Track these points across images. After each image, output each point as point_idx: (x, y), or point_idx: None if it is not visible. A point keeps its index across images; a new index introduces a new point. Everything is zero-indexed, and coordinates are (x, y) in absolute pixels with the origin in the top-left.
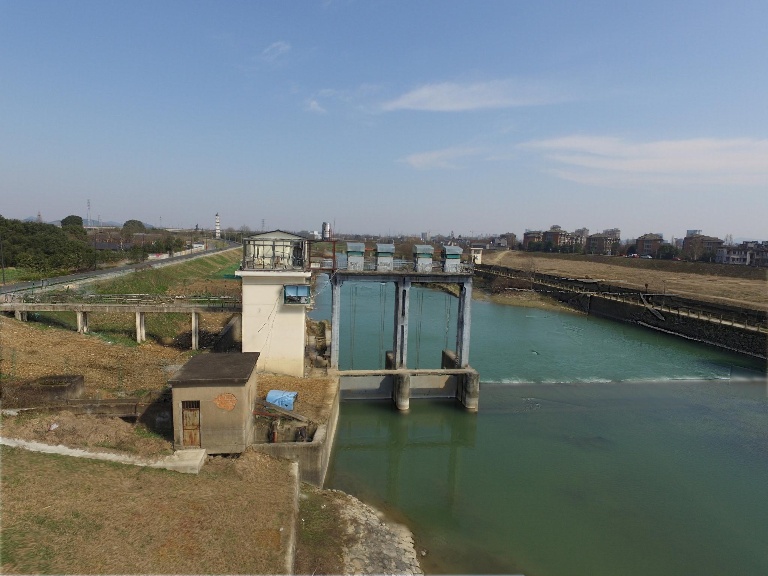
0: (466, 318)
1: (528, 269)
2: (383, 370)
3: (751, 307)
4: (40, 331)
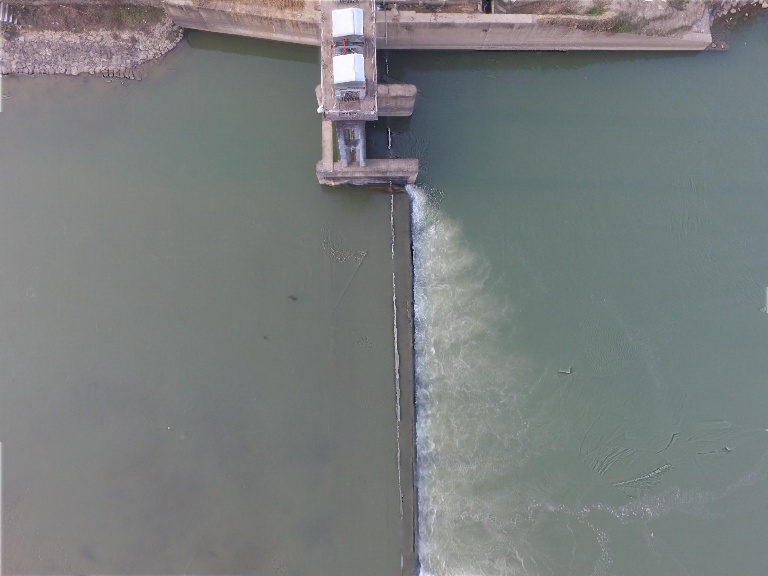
0: None
1: None
2: None
3: None
4: None
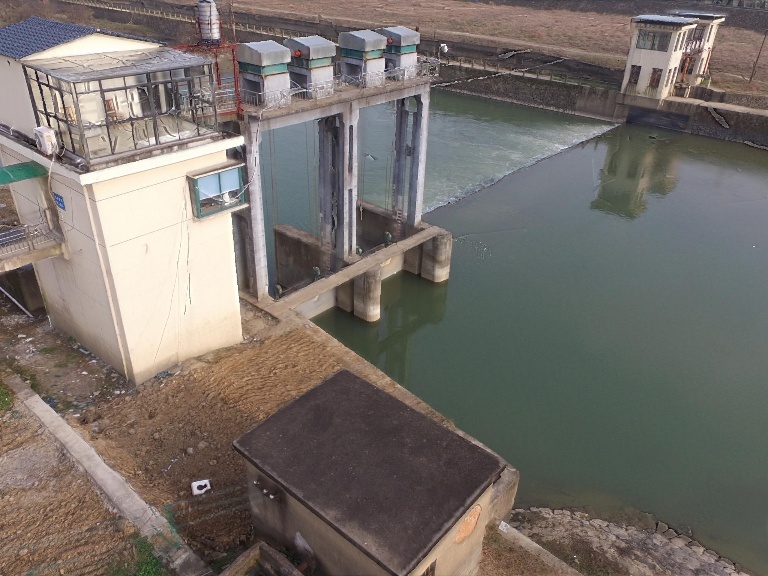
0: (422, 151)
1: (226, 8)
2: (341, 273)
3: (499, 44)
4: None
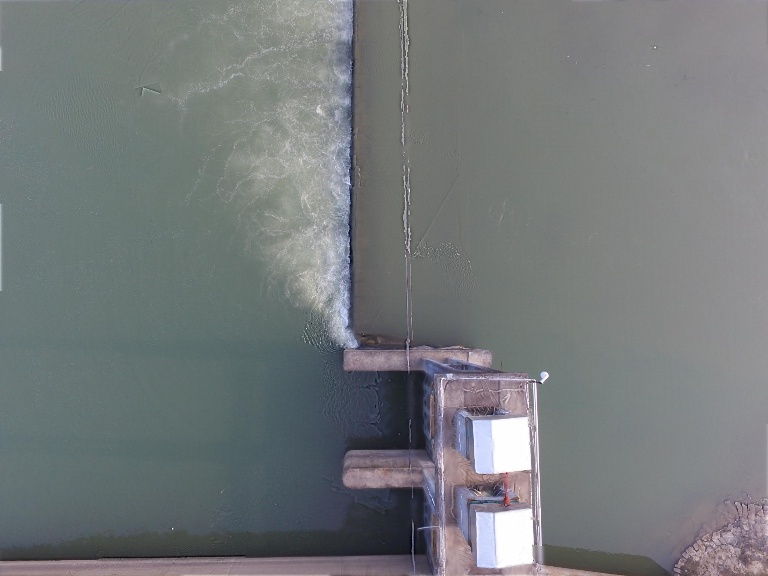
0: None
1: None
2: None
3: None
4: None
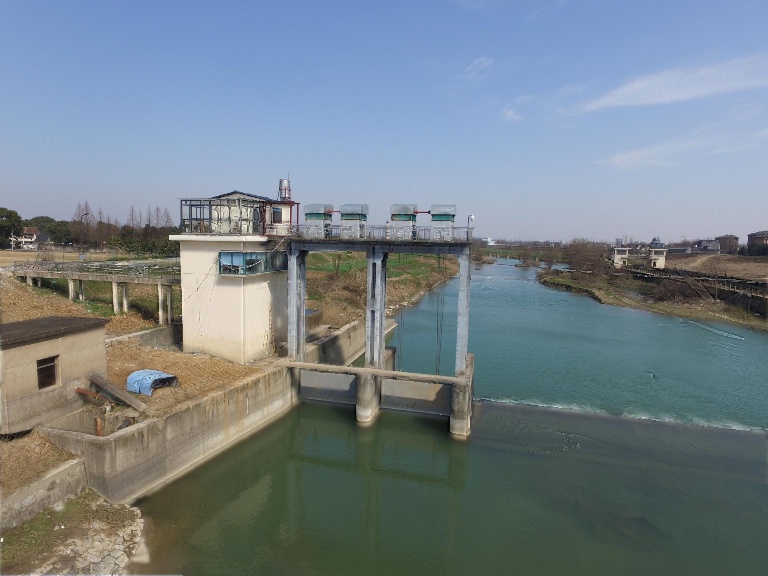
0: (461, 305)
1: (712, 270)
2: None
3: None
4: (37, 296)
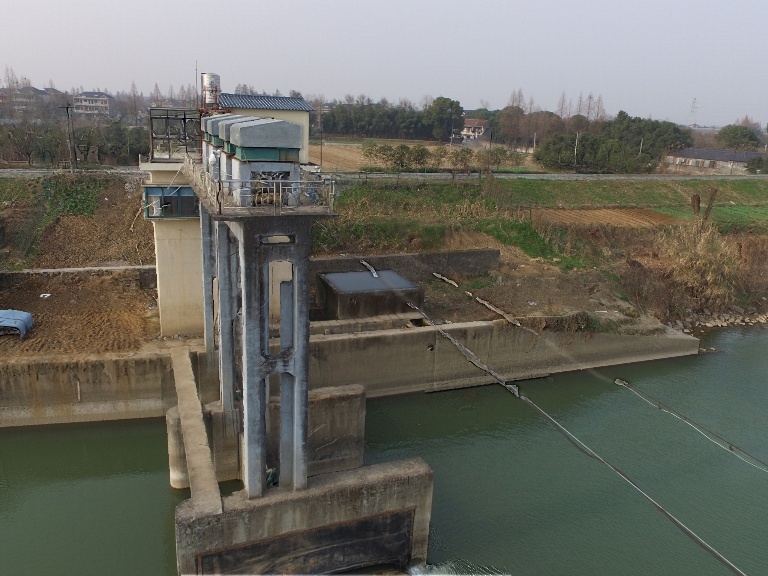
0: None
1: None
2: (191, 387)
3: None
4: None
